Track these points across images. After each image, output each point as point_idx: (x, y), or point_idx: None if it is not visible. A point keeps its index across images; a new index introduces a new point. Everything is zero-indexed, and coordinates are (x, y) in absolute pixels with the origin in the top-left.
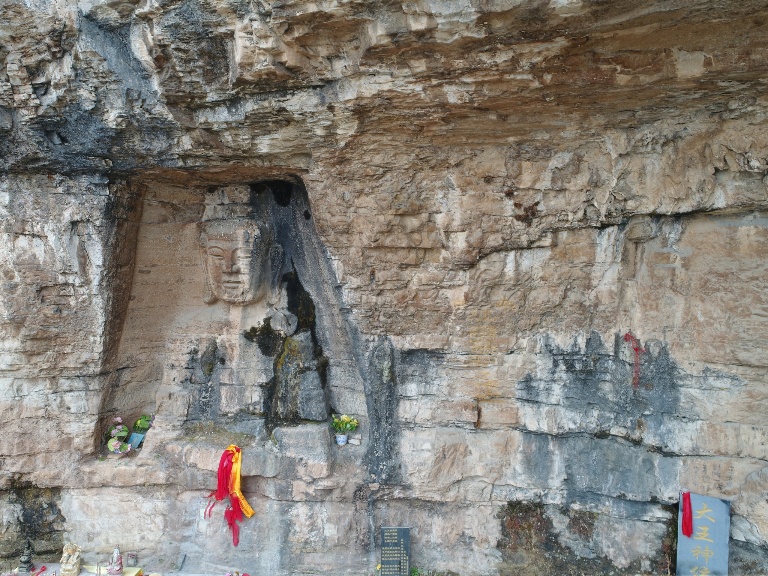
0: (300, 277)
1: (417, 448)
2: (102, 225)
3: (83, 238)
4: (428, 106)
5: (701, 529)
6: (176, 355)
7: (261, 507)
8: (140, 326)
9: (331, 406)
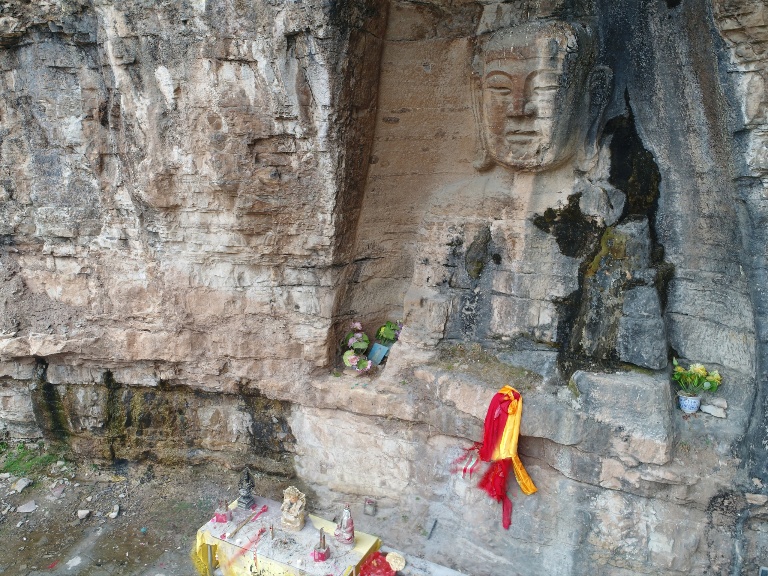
0: (638, 124)
1: None
2: (327, 36)
3: (304, 62)
4: None
5: None
6: (431, 246)
7: (547, 483)
8: (384, 202)
9: (671, 345)
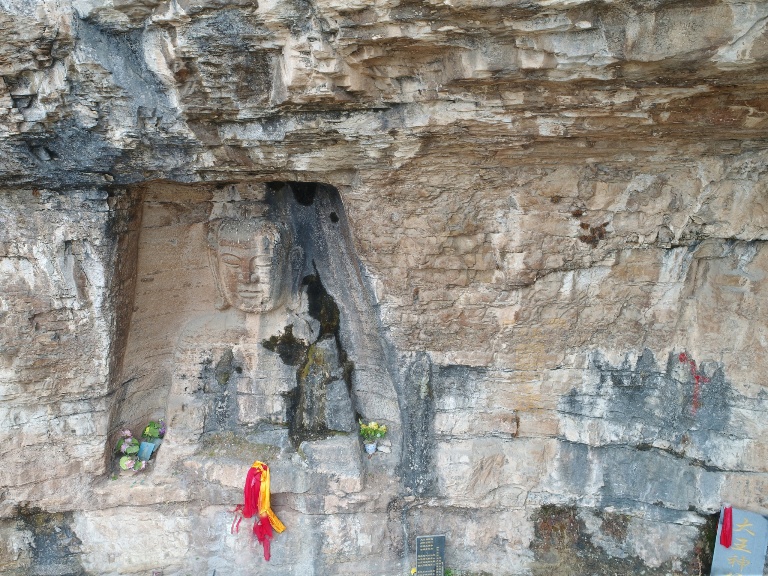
0: (323, 280)
1: (454, 461)
2: (102, 244)
3: (79, 257)
4: (512, 135)
5: (740, 541)
6: (187, 365)
7: (292, 521)
8: (144, 336)
9: (357, 411)
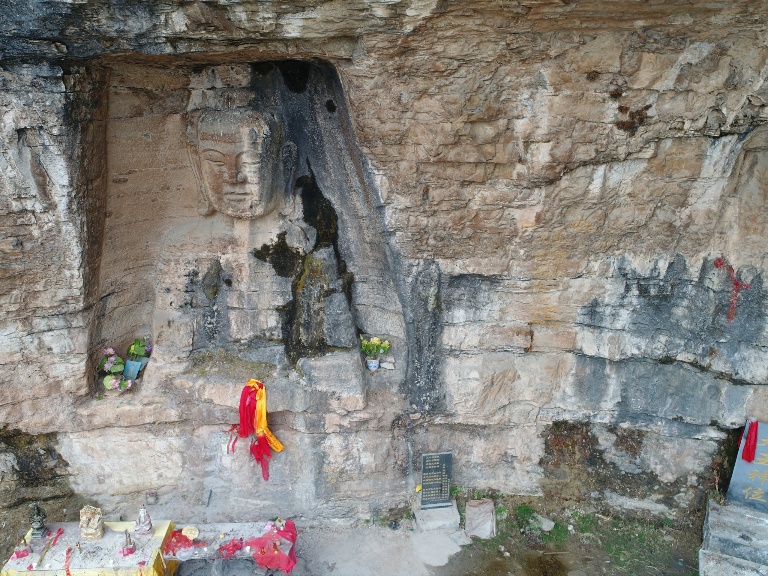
0: (318, 181)
1: (463, 377)
2: (62, 134)
3: (36, 150)
4: None
5: (763, 455)
6: (171, 278)
7: (290, 440)
8: (122, 245)
9: (358, 326)
